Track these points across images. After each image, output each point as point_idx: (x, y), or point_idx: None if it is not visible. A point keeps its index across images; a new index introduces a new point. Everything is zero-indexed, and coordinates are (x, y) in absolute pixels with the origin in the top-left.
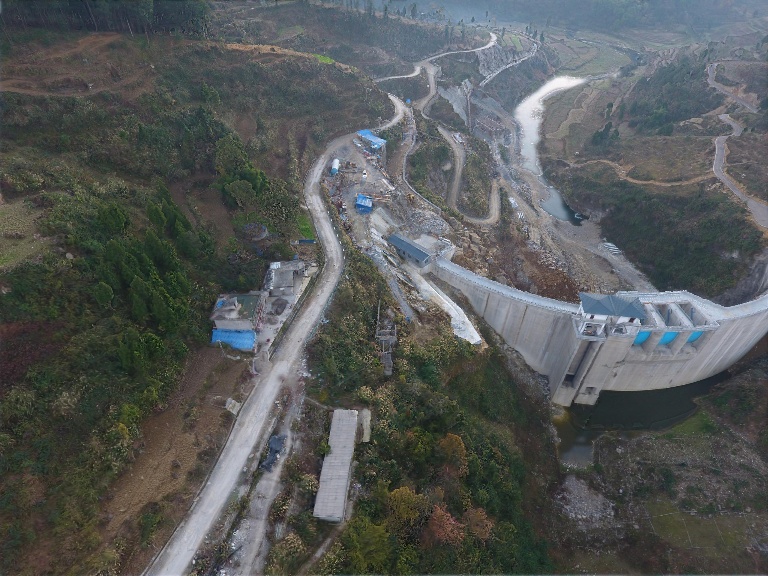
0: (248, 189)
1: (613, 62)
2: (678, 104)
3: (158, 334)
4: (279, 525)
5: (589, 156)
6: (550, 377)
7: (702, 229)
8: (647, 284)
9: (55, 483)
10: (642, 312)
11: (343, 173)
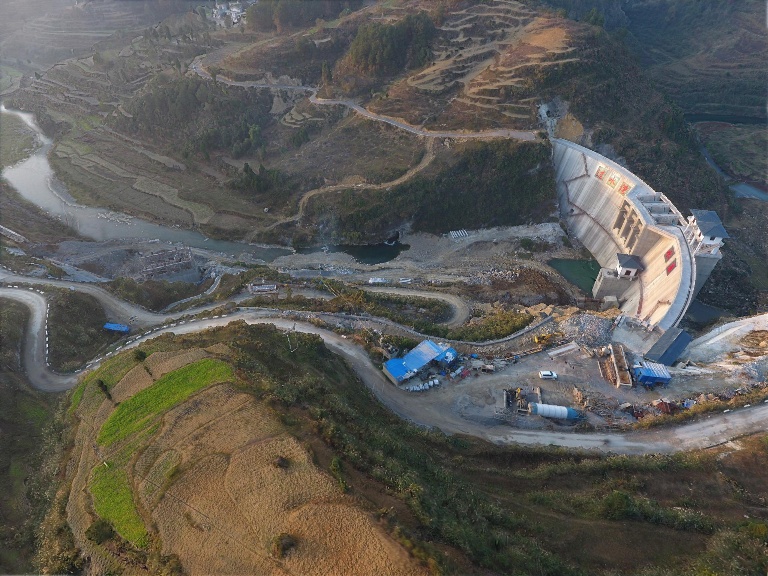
0: None
1: (2, 124)
2: (248, 115)
3: None
4: None
5: (283, 202)
6: None
7: (504, 169)
8: (512, 229)
9: None
10: None
11: (583, 396)
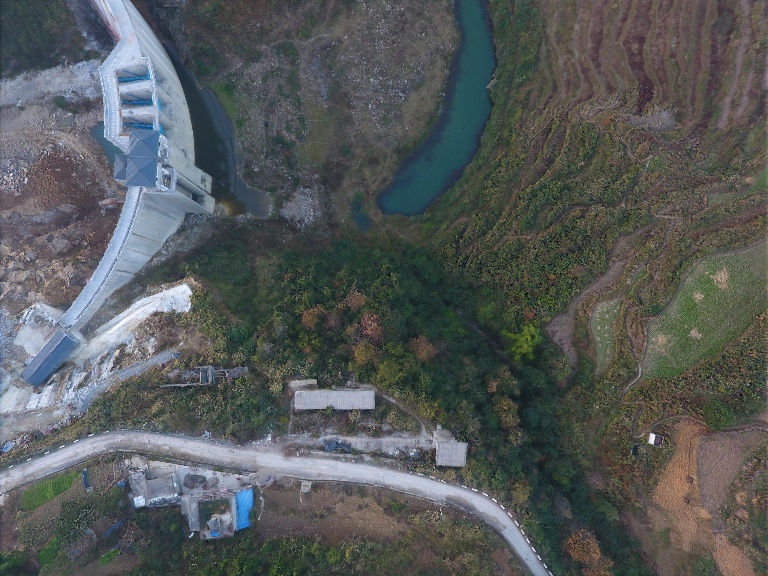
0: (54, 567)
1: None
2: None
3: (264, 570)
4: (383, 429)
5: None
6: (189, 212)
7: None
8: (43, 76)
9: (387, 575)
10: (151, 133)
11: None
